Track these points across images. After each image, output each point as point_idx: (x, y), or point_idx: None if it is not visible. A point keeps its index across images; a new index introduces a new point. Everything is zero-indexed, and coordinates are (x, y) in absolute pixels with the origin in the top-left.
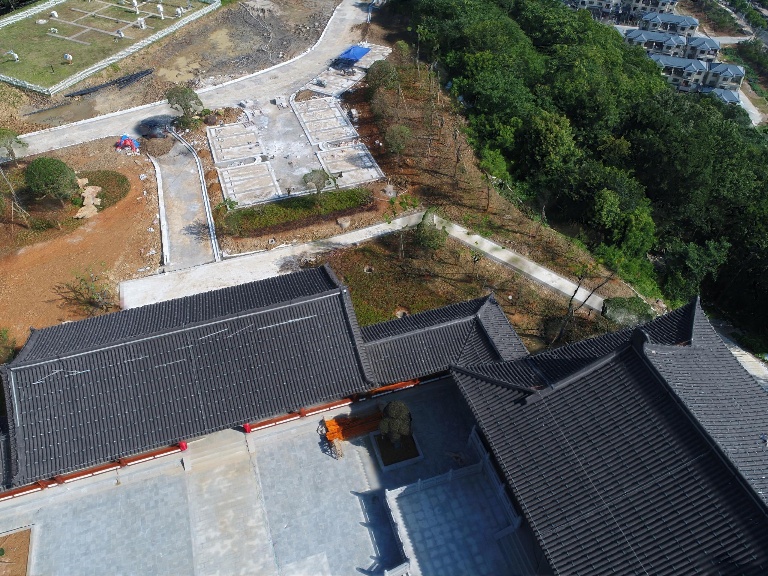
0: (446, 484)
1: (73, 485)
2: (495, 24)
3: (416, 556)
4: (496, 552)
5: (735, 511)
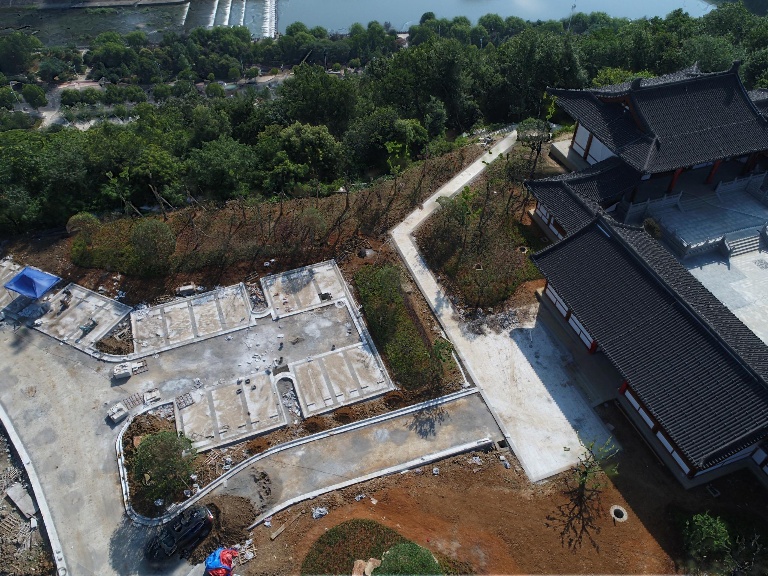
0: None
1: None
2: (91, 136)
3: None
4: (692, 213)
5: (707, 88)
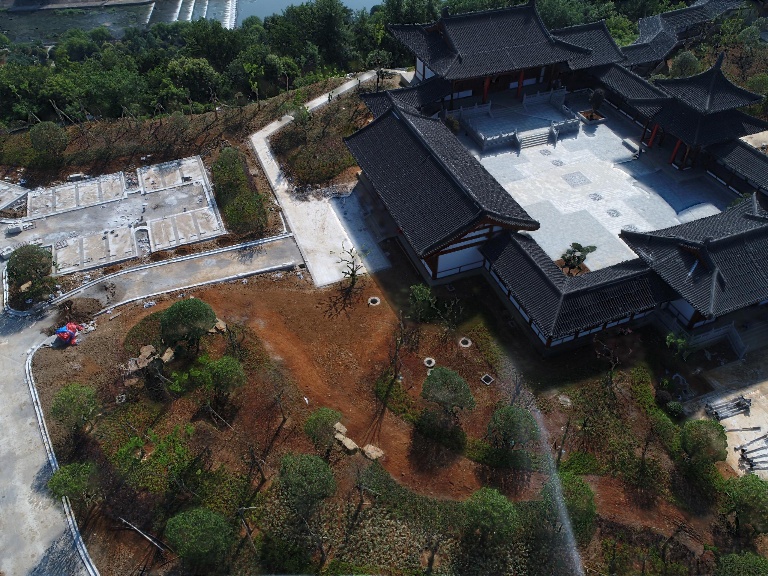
0: None
1: None
2: (5, 67)
3: None
4: (500, 119)
5: (509, 17)
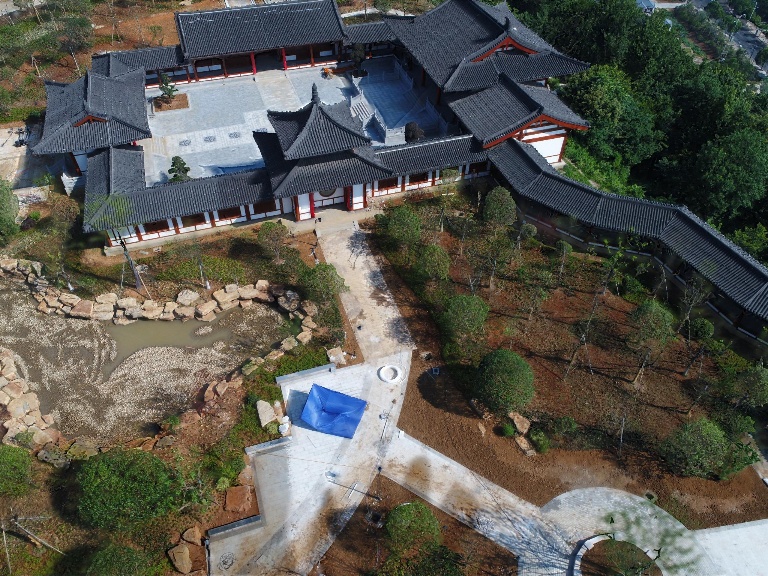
0: (382, 82)
1: (203, 83)
2: None
3: (366, 98)
4: (402, 97)
5: (485, 26)
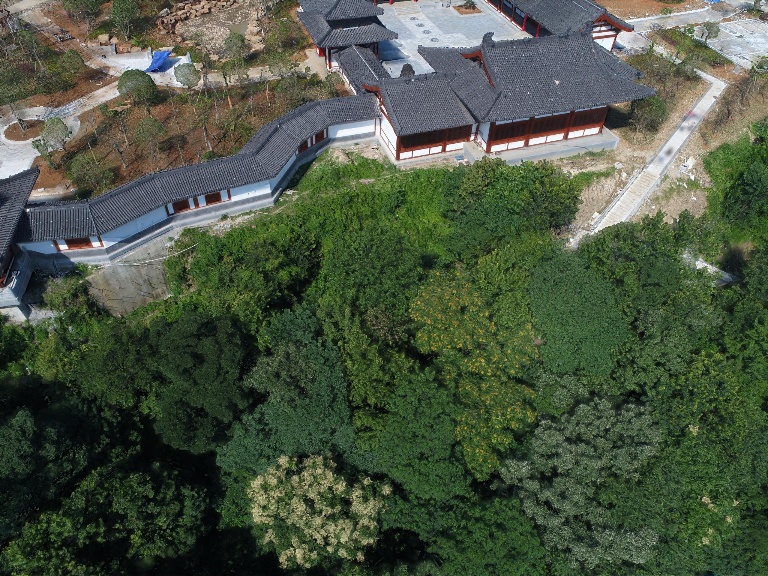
0: None
1: (501, 15)
2: None
3: None
4: None
5: None
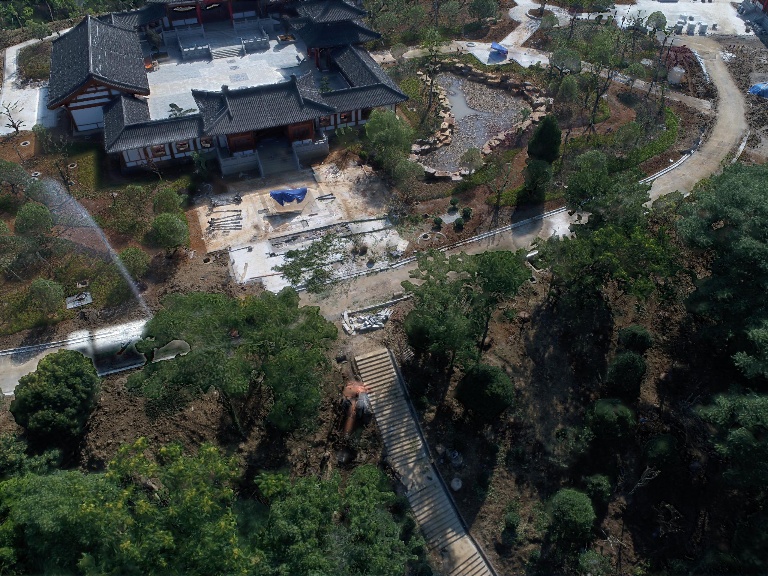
0: None
1: None
2: None
3: None
4: (211, 39)
5: None
